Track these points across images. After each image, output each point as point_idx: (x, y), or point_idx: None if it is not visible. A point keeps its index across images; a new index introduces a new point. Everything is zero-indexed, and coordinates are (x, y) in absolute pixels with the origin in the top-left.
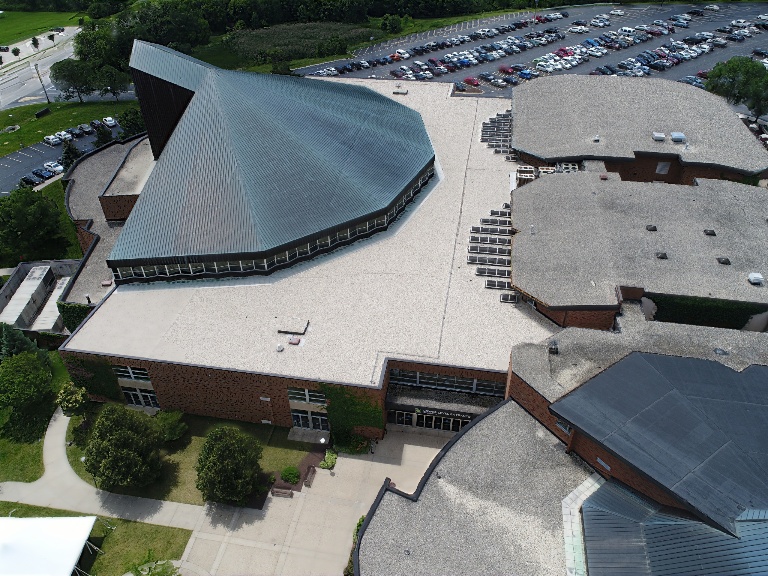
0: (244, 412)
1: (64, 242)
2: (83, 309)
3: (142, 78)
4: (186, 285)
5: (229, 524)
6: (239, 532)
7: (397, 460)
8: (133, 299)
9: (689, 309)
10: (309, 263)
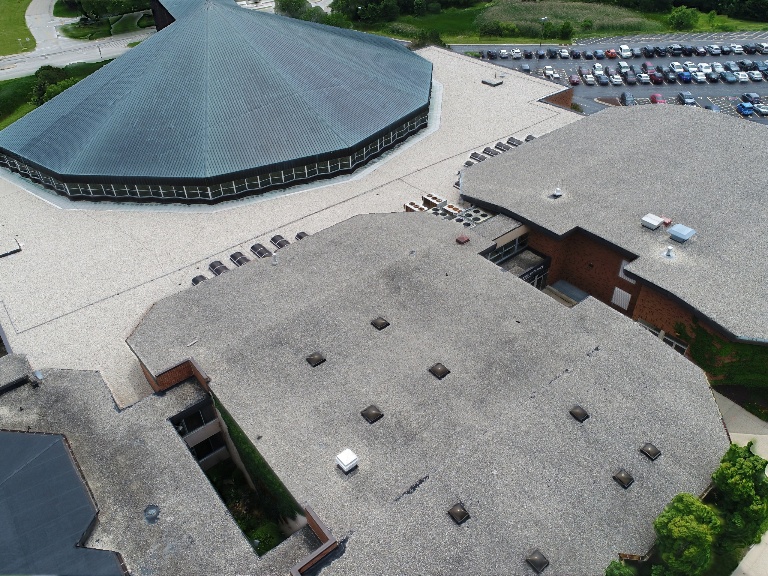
0: None
1: None
2: None
3: None
4: (23, 184)
5: None
6: None
7: None
8: None
9: (238, 442)
10: (111, 205)
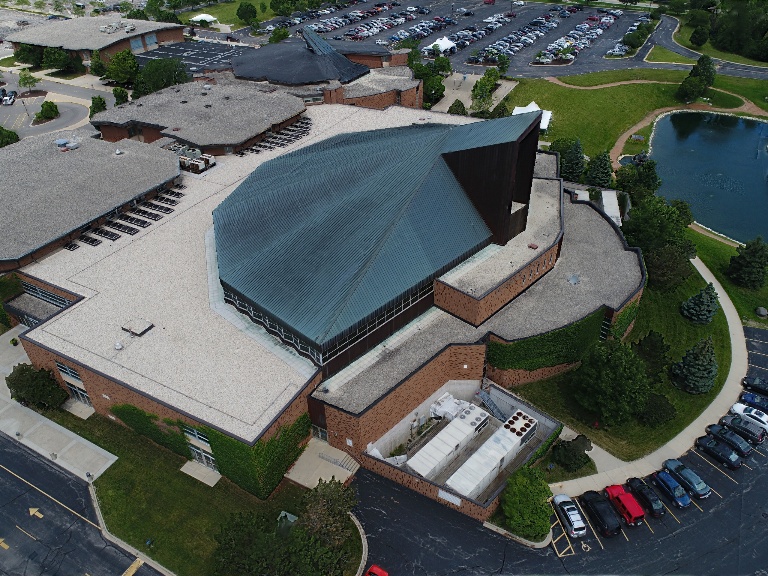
0: None
1: None
2: None
3: None
4: None
5: None
6: None
7: None
8: None
9: None
10: None
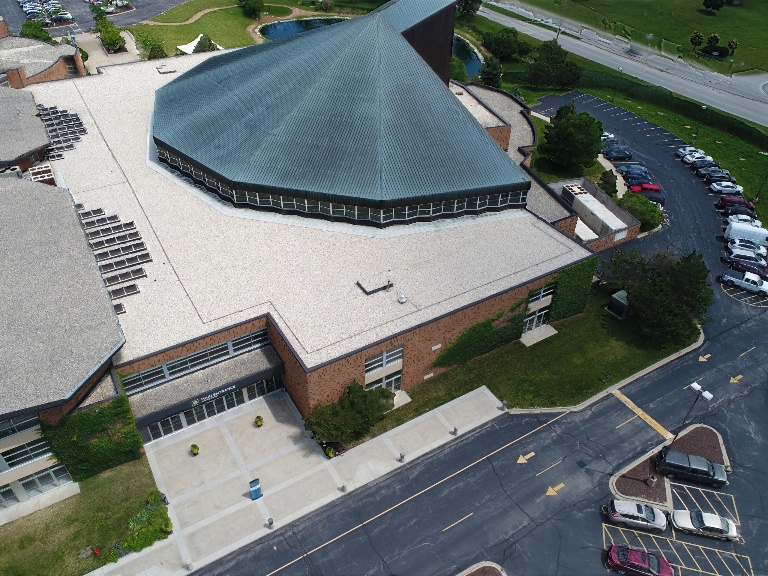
0: None
1: None
2: None
3: None
4: None
5: None
6: None
7: None
8: None
9: None
10: None
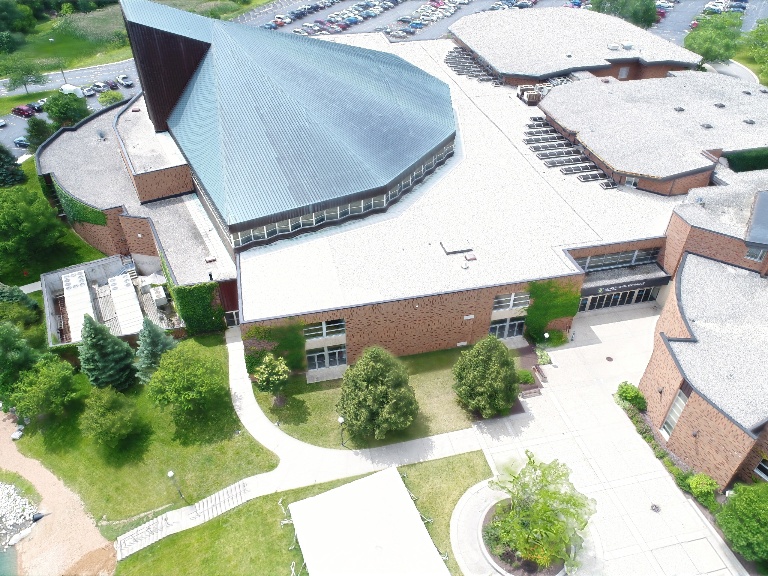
0: (441, 340)
1: (66, 247)
2: (210, 287)
3: (144, 34)
4: (312, 237)
5: (509, 433)
6: (524, 436)
7: (596, 340)
8: (270, 262)
9: (753, 160)
10: (413, 194)
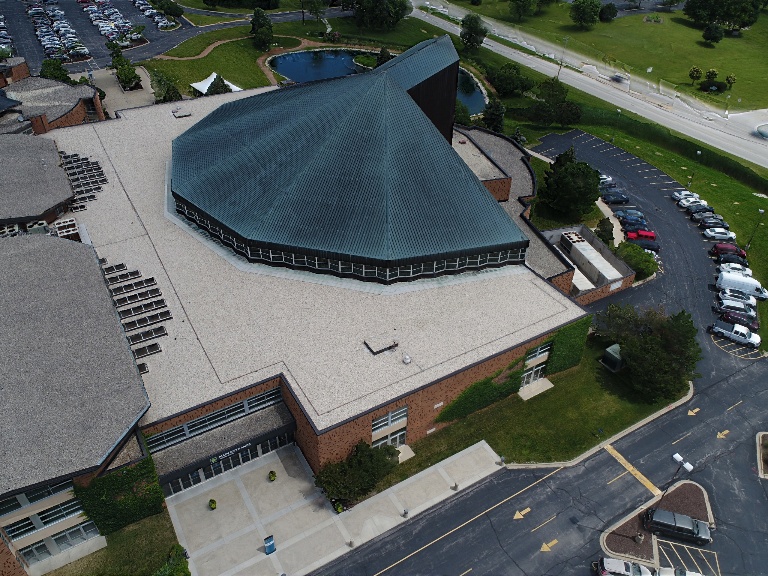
0: None
1: None
2: None
3: None
4: None
5: None
6: None
7: None
8: None
9: None
10: None
